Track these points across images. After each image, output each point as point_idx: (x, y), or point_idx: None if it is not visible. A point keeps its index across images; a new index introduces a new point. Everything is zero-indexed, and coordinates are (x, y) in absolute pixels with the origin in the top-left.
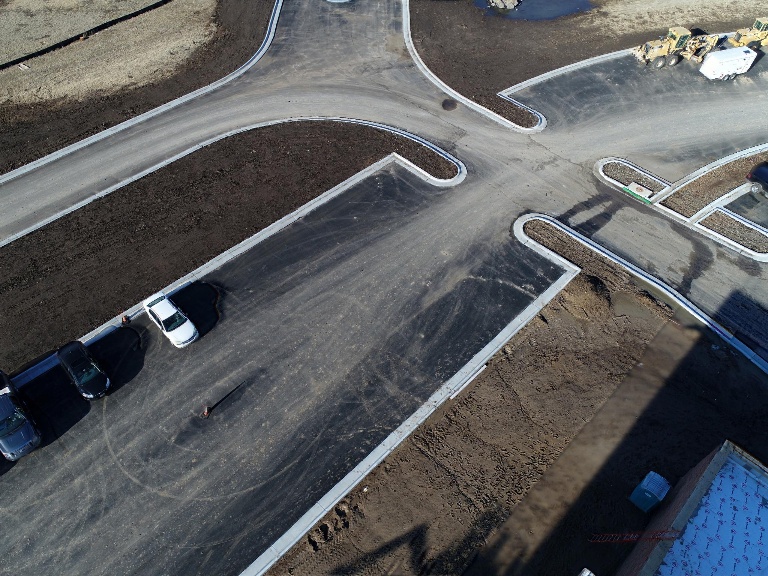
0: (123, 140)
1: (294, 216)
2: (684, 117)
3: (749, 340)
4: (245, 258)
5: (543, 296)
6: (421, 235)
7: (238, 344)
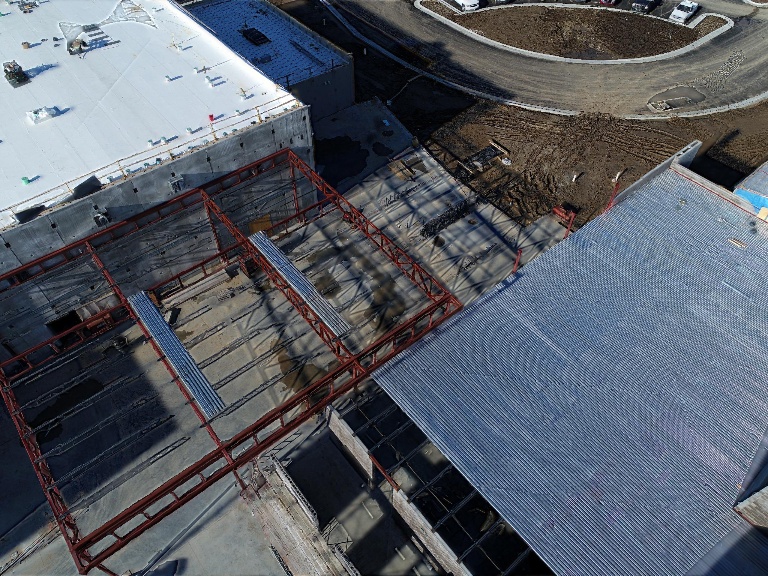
0: None
1: None
2: None
3: (337, 6)
4: None
5: None
6: None
7: None
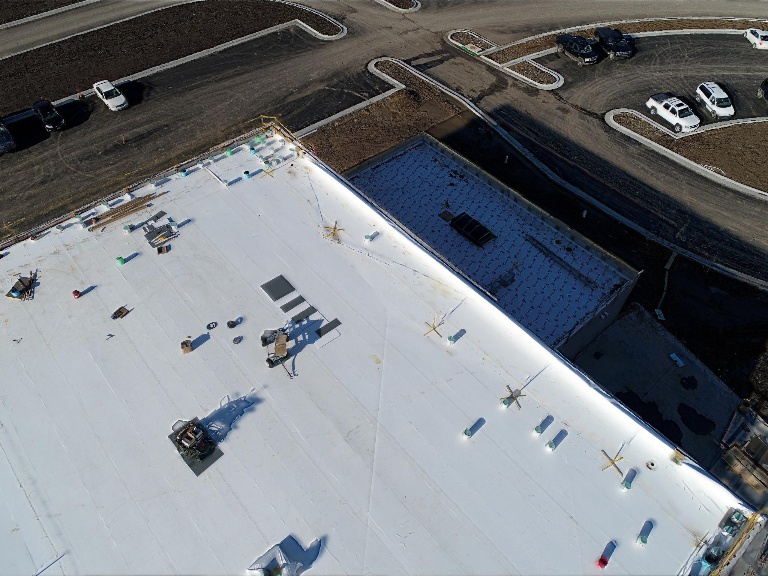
0: (101, 6)
1: (212, 51)
2: (530, 7)
3: (507, 127)
4: (171, 71)
5: (372, 99)
6: (299, 65)
7: (154, 112)
